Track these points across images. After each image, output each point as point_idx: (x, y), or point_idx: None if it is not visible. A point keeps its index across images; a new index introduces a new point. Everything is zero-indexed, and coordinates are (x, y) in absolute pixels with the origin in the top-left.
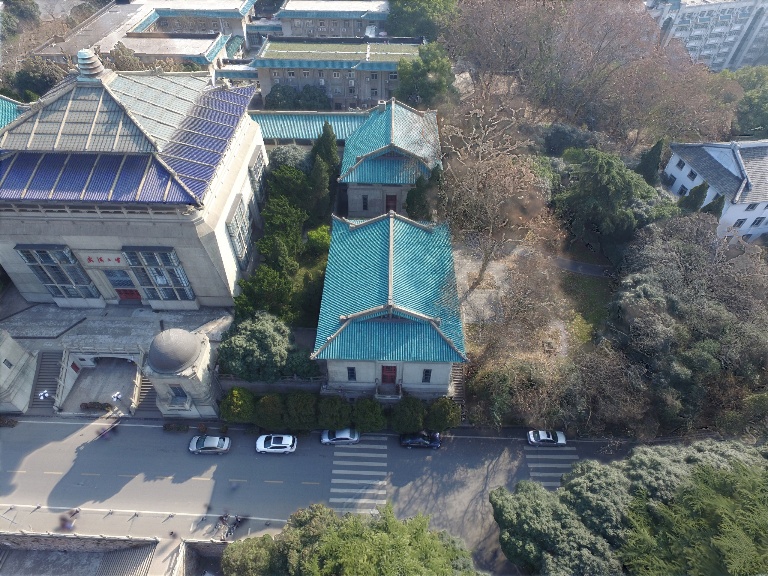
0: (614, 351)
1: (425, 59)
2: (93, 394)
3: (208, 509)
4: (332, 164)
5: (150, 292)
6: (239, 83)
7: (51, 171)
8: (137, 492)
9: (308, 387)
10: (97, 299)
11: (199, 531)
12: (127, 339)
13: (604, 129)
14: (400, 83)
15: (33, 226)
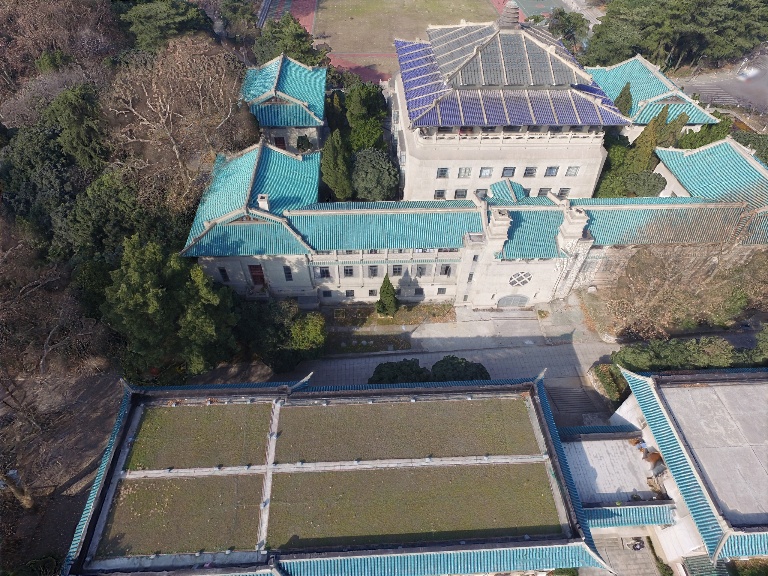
0: (160, 90)
1: None
2: None
3: None
4: None
5: None
6: None
7: None
8: None
9: None
10: None
11: None
12: None
13: None
14: (221, 293)
15: None
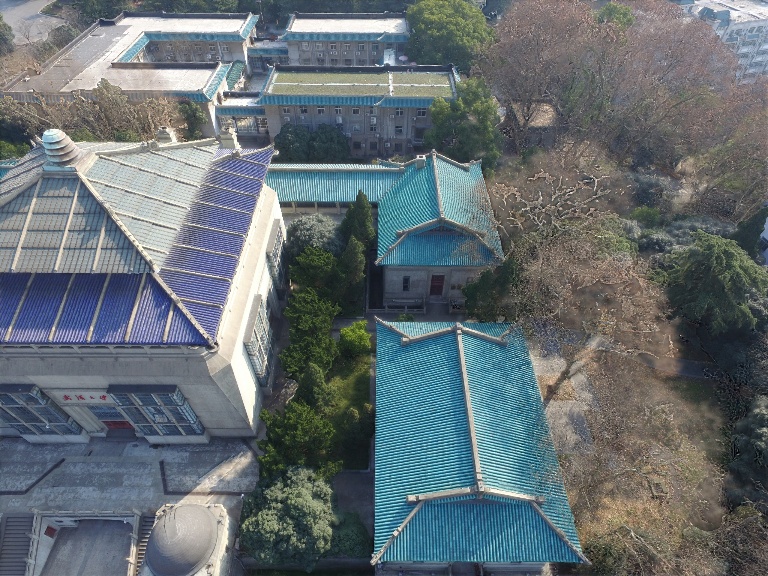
0: (764, 520)
1: (464, 98)
2: (74, 570)
3: None
4: (366, 239)
5: (146, 427)
6: (243, 120)
7: (9, 297)
8: None
9: (356, 561)
10: (78, 435)
11: None
12: (117, 492)
13: (648, 160)
14: (435, 126)
15: None
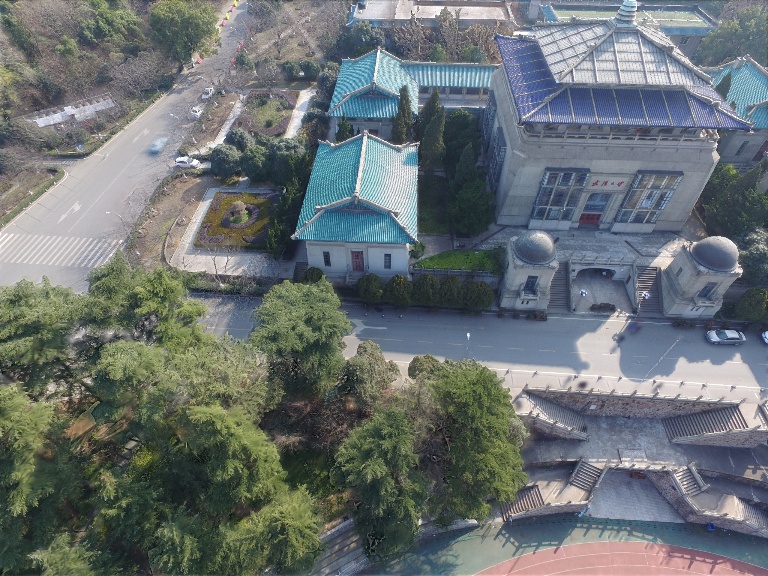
0: None
1: None
2: (590, 299)
3: (759, 384)
4: None
5: (622, 215)
6: None
7: (607, 102)
8: (690, 370)
9: None
10: (570, 221)
11: (765, 399)
12: (610, 254)
13: None
14: (720, 45)
15: (570, 151)
